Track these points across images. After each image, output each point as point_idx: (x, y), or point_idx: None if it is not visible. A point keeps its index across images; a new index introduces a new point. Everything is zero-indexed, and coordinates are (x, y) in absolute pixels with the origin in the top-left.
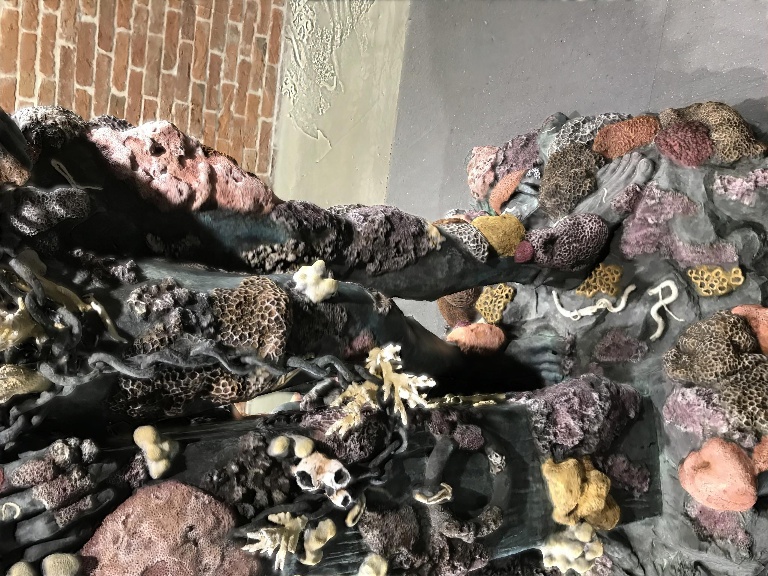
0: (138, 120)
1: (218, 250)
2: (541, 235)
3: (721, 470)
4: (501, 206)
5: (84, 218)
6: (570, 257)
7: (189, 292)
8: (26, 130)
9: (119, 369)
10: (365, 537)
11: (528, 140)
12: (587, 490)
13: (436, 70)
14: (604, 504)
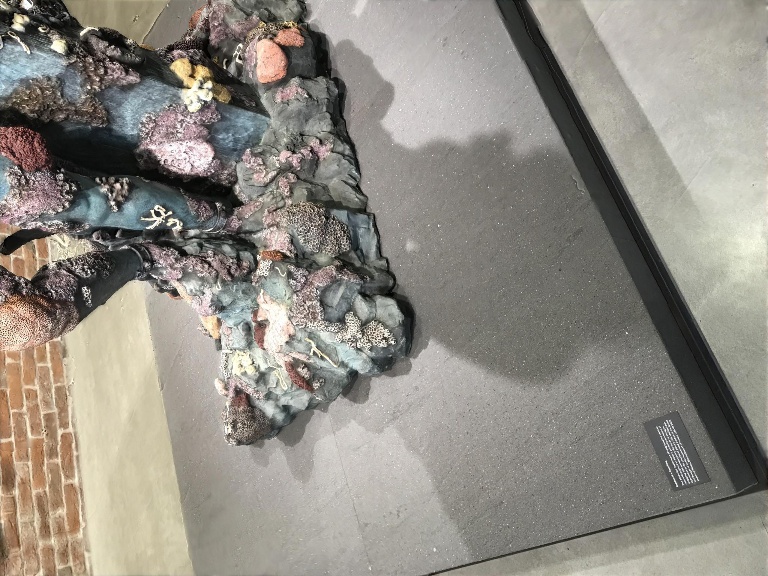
0: None
1: None
2: None
3: (260, 46)
4: None
5: None
6: None
7: None
8: None
9: None
10: (52, 38)
11: None
12: (197, 69)
13: None
14: None
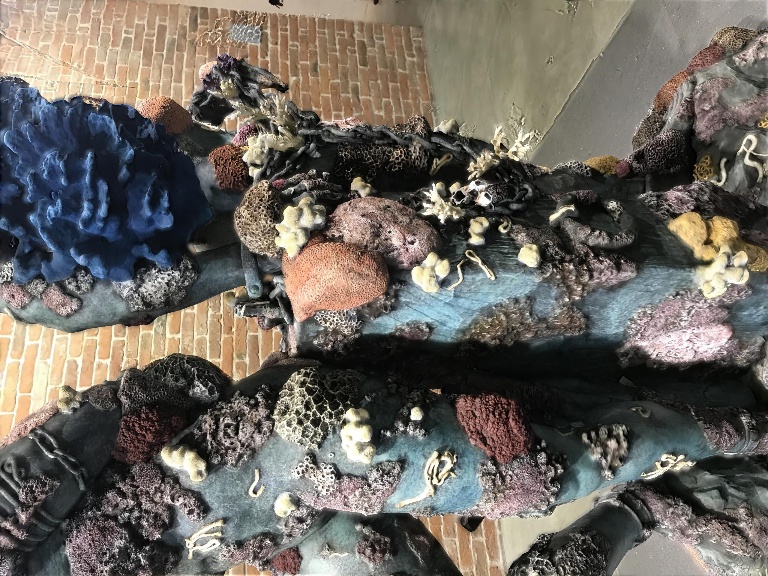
0: None
1: None
2: (631, 154)
3: None
4: None
5: None
6: (659, 157)
7: None
8: None
9: (336, 132)
10: (517, 239)
11: None
12: (713, 226)
13: None
14: (737, 235)
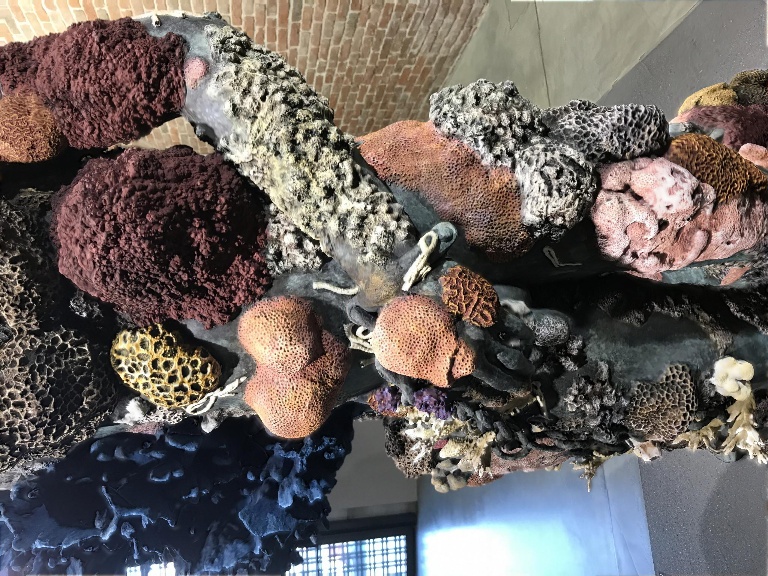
0: None
1: None
2: None
3: None
4: None
5: None
6: None
7: (615, 401)
8: (531, 227)
9: None
10: None
11: None
12: None
13: None
14: None
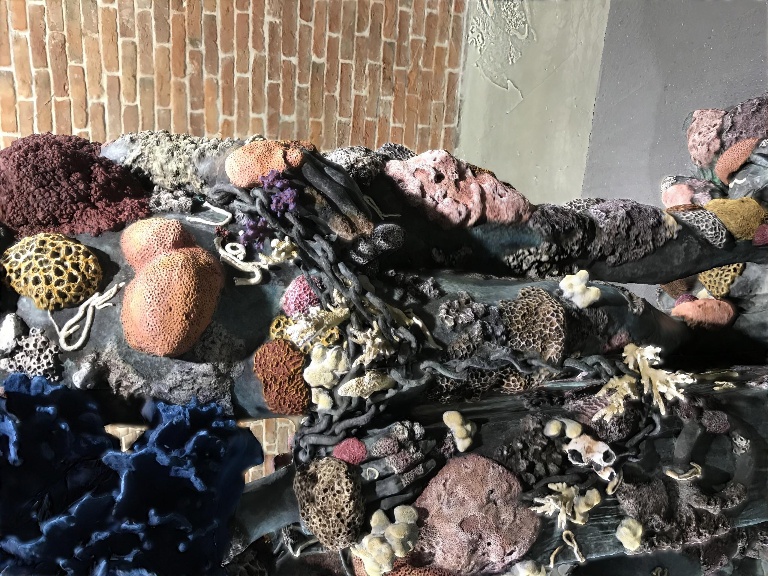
0: (336, 84)
1: (485, 256)
2: None
3: None
4: (728, 176)
5: (399, 247)
6: None
7: (484, 306)
8: None
9: (443, 373)
10: (622, 503)
11: (761, 105)
12: None
13: (648, 23)
14: None
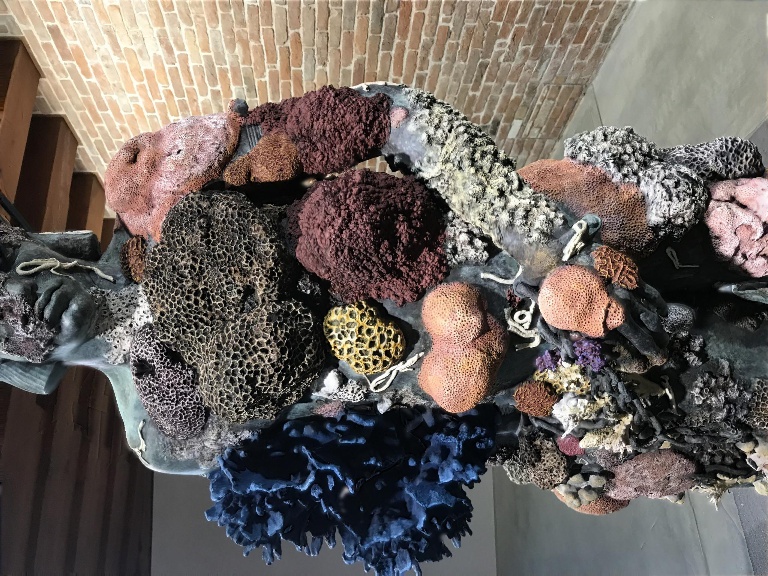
0: None
1: None
2: None
3: None
4: None
5: None
6: None
7: (738, 394)
8: (657, 227)
9: None
10: None
11: None
12: None
13: None
14: None
